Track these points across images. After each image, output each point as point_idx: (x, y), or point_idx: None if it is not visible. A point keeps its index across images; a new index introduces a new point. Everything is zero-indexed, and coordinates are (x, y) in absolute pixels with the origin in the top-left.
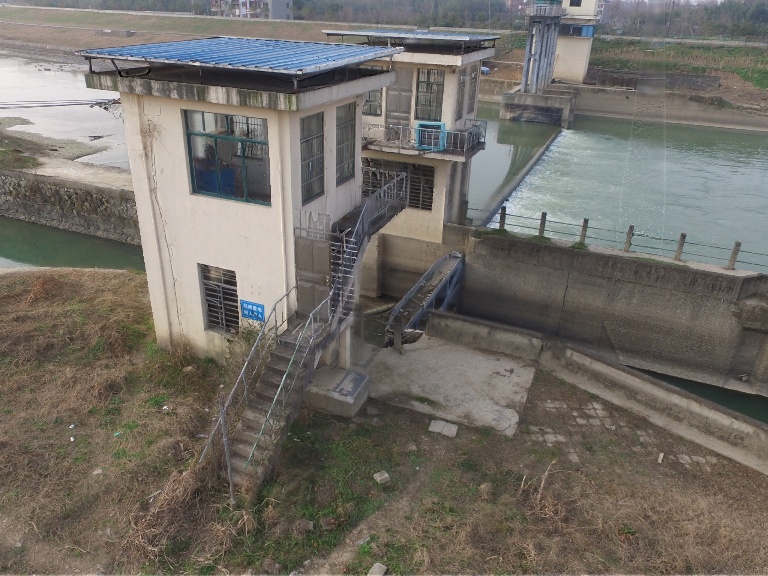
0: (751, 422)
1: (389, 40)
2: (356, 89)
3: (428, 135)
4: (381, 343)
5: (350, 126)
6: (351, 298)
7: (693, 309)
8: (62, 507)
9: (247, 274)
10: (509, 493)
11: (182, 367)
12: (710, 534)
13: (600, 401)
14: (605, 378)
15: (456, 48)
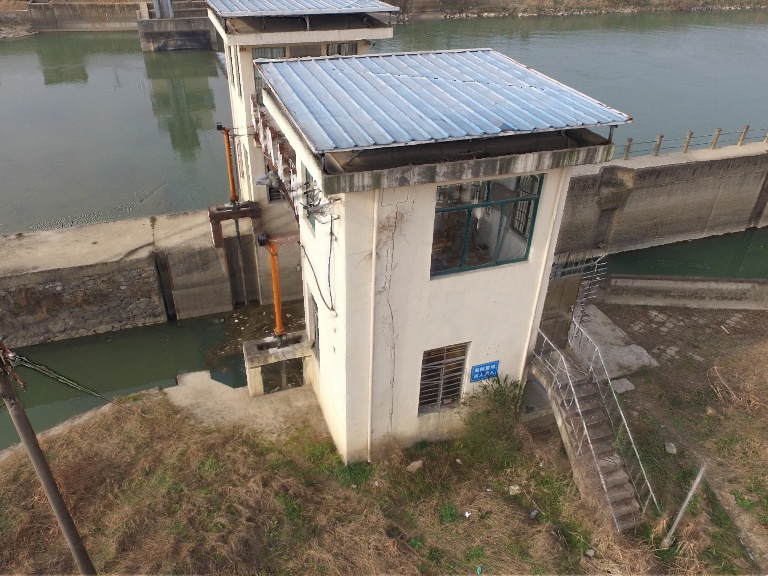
0: (752, 281)
1: (307, 18)
2: None
3: None
4: None
5: None
6: None
7: (573, 208)
8: None
9: (487, 338)
10: (720, 406)
11: (405, 468)
12: None
13: (651, 308)
14: (646, 290)
15: (362, 17)
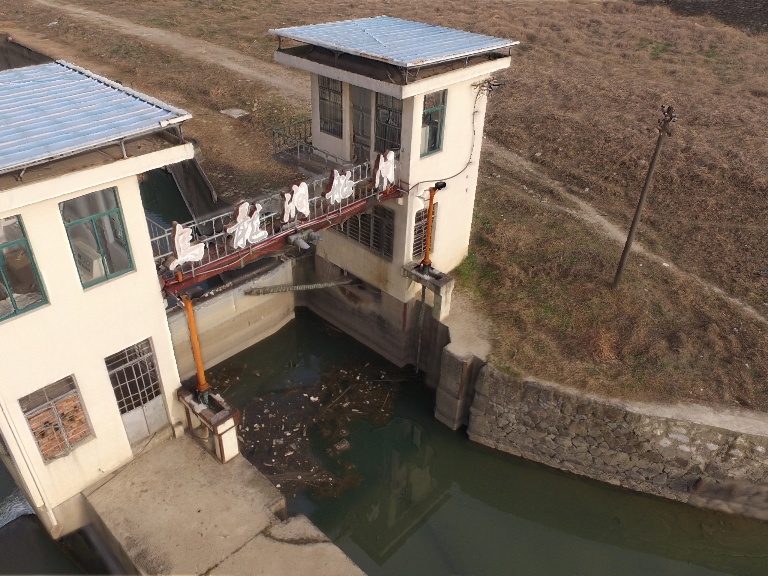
0: None
1: None
2: None
3: None
4: (247, 376)
5: None
6: None
7: None
8: None
9: None
10: None
11: None
12: None
13: None
14: None
15: None
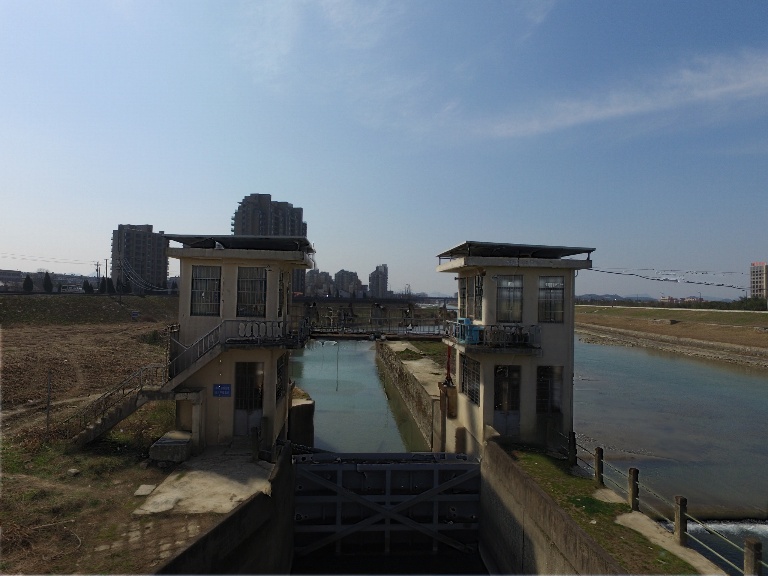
0: None
1: None
2: (238, 255)
3: None
4: None
5: (259, 282)
6: (262, 410)
7: None
8: (58, 418)
9: None
10: (49, 518)
11: None
12: None
13: None
14: None
15: (492, 255)
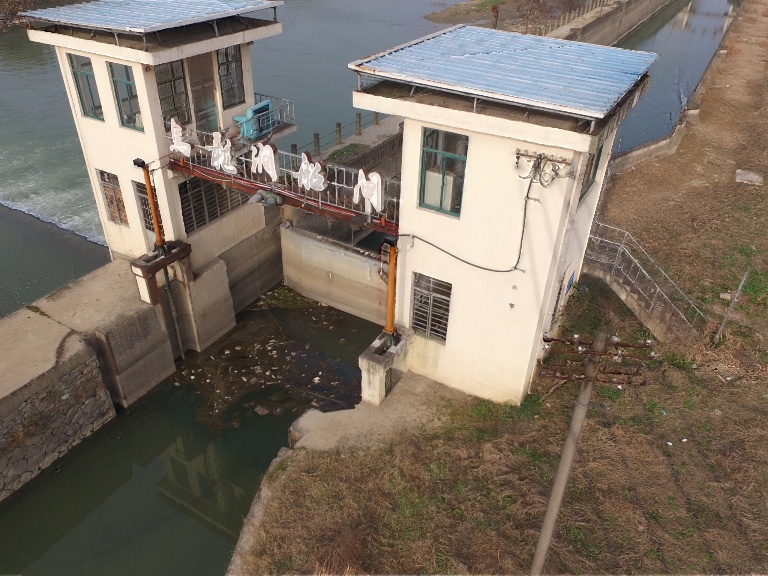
0: None
1: (215, 23)
2: None
3: (266, 119)
4: (337, 332)
5: None
6: None
7: None
8: (767, 419)
9: None
10: None
11: None
12: (636, 214)
13: None
14: None
15: None
